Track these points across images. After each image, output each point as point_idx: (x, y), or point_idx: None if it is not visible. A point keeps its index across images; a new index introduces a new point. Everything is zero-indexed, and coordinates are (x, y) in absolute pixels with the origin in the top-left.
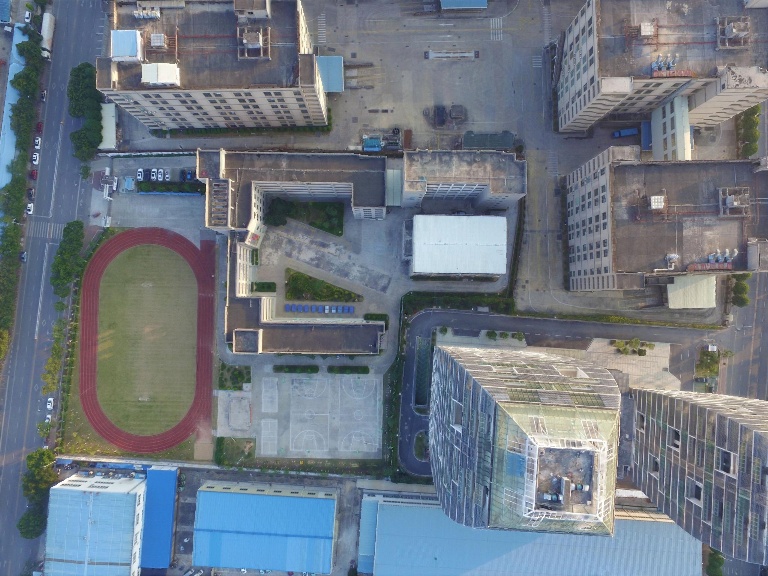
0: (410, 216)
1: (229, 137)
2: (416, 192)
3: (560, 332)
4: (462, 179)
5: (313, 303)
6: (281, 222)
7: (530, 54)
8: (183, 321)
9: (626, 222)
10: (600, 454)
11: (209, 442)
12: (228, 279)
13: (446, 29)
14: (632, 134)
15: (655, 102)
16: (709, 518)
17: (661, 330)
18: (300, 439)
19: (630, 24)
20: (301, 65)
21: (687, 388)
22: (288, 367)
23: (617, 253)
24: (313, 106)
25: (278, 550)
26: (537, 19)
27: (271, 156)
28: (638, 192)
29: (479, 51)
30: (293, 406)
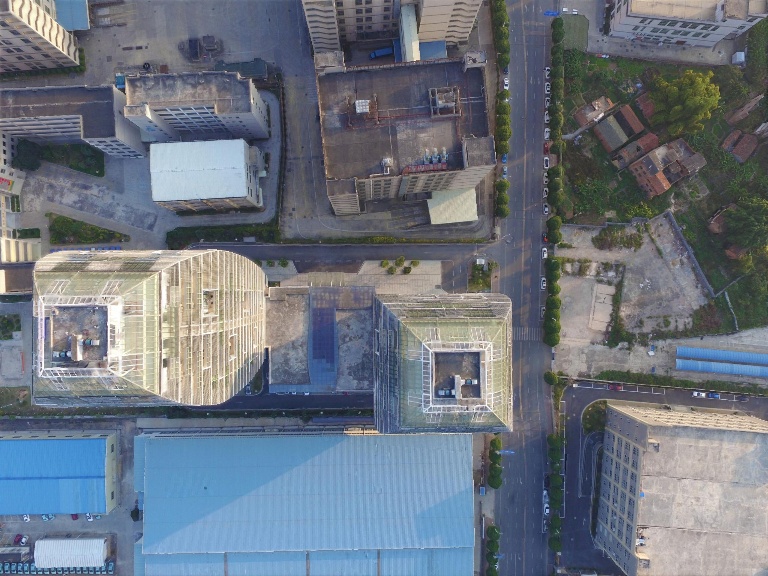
0: None
1: None
2: (138, 117)
3: (330, 257)
4: (187, 102)
5: (79, 246)
6: (31, 164)
7: None
8: None
9: (339, 130)
10: (107, 307)
11: None
12: None
13: None
14: (387, 54)
15: (390, 15)
16: None
17: (431, 248)
18: None
19: None
20: None
21: None
22: None
23: (332, 161)
24: (38, 40)
25: (51, 493)
26: None
27: None
28: (349, 99)
29: None
30: None
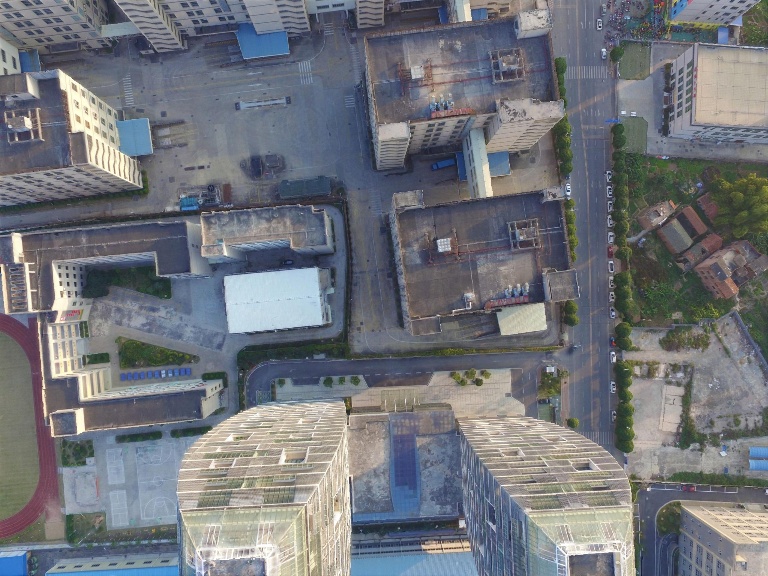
0: (238, 270)
1: (45, 211)
2: None
3: (400, 370)
4: (262, 237)
5: (149, 369)
6: (101, 294)
7: (342, 94)
8: (19, 402)
9: (420, 266)
10: (266, 561)
11: (59, 521)
12: (42, 362)
13: (255, 78)
14: (450, 165)
15: (456, 135)
16: (487, 568)
17: (500, 356)
18: (151, 507)
19: (404, 67)
20: (72, 144)
21: (531, 411)
22: (130, 437)
23: (414, 298)
24: (109, 177)
25: None
26: (345, 58)
27: (70, 233)
28: (429, 235)
29: (290, 97)
30: (140, 475)
